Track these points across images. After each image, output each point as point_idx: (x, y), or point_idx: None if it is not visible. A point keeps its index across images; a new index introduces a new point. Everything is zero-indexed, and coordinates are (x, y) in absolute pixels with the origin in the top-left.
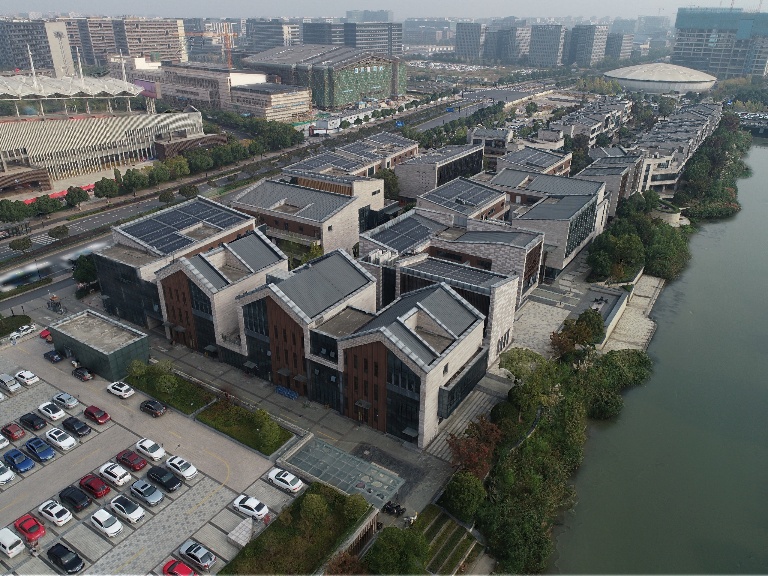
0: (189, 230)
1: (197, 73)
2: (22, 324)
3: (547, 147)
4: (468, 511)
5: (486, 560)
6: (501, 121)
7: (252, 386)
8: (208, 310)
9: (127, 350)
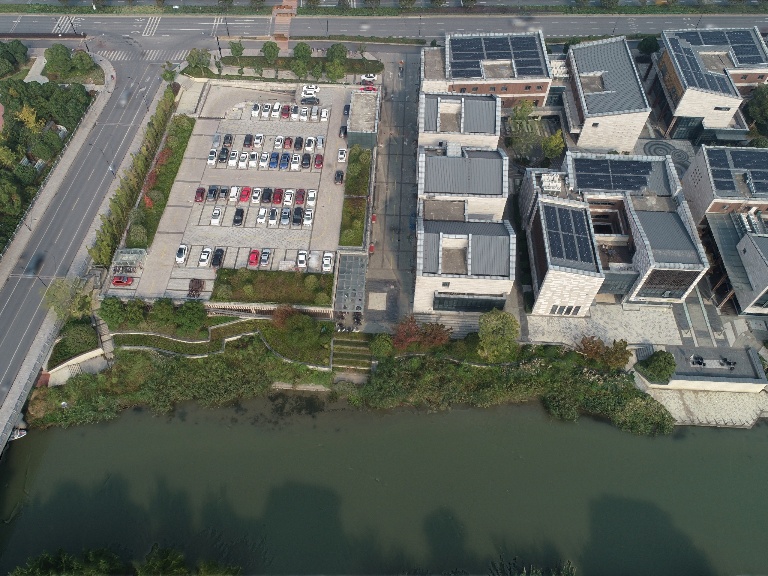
0: (495, 63)
1: None
2: (375, 71)
3: None
4: None
5: (364, 379)
6: None
7: (407, 203)
8: None
9: (361, 135)
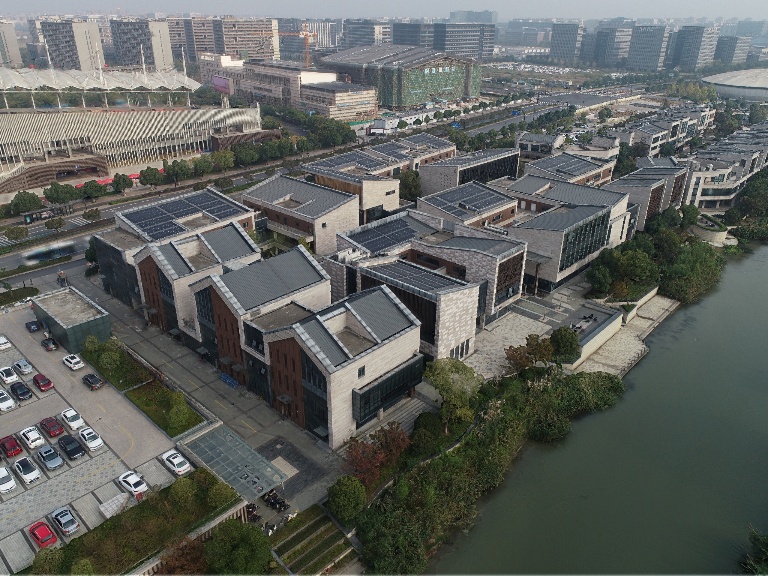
0: (187, 219)
1: (272, 71)
2: (29, 295)
3: (598, 155)
4: (344, 516)
5: (357, 568)
6: (566, 126)
7: (201, 371)
8: (171, 295)
9: (87, 326)
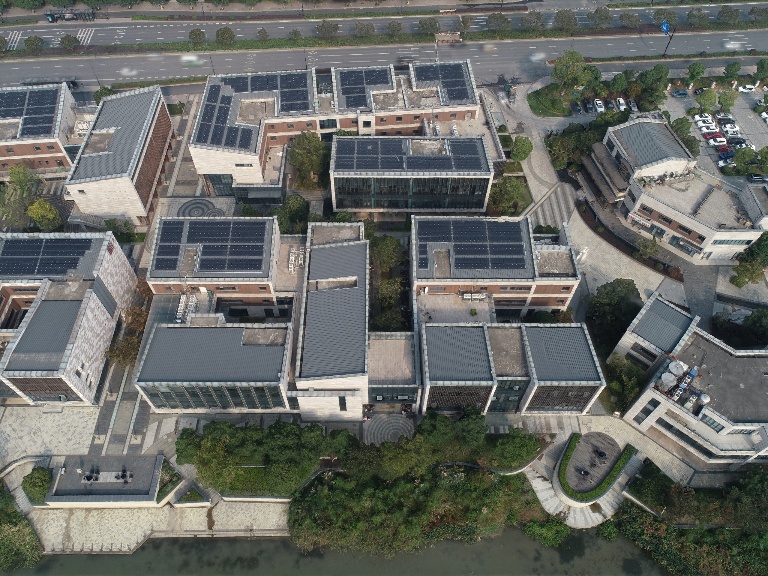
0: (3, 121)
1: None
2: None
3: (696, 226)
4: None
5: None
6: None
7: None
8: None
9: None
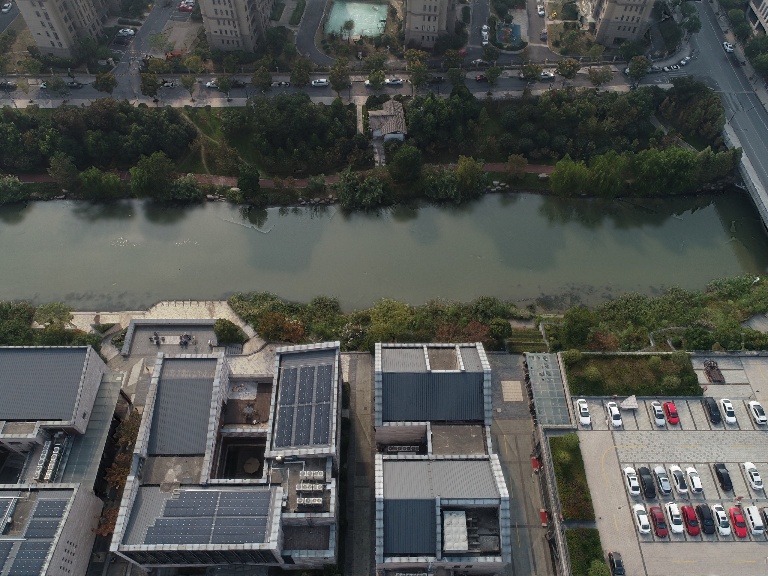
0: None
1: None
2: None
3: None
4: None
5: None
6: None
7: None
8: None
9: None
